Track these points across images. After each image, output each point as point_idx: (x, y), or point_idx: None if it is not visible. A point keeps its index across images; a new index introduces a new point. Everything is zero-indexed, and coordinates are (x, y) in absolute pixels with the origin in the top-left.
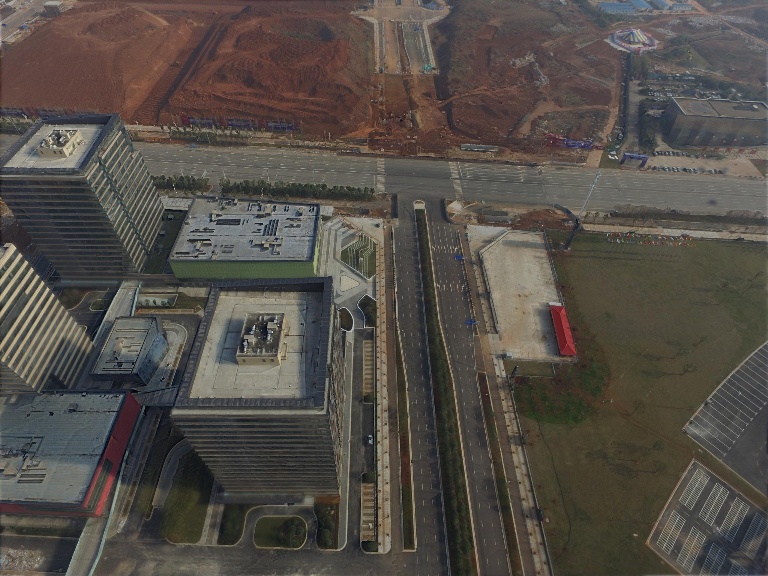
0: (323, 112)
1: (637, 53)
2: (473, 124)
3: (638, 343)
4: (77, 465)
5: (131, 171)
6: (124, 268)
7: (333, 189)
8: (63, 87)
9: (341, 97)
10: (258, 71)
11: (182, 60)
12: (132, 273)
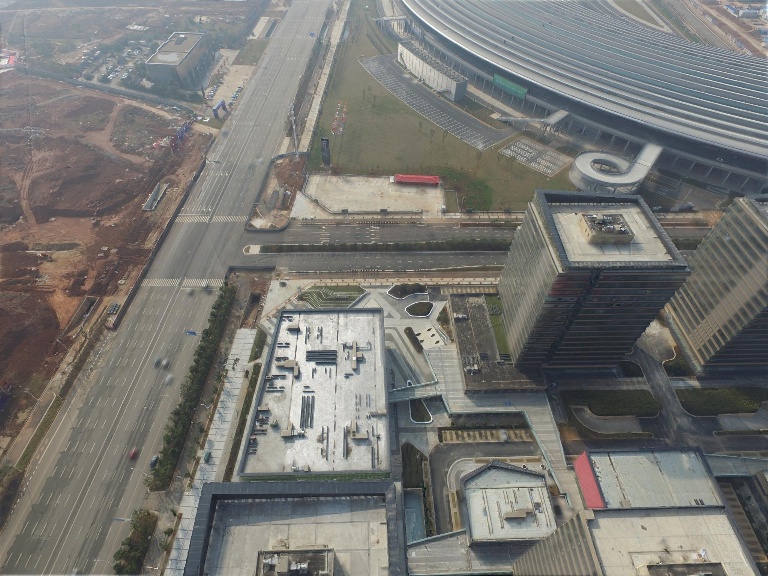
0: None
1: (22, 65)
2: (106, 194)
3: (421, 152)
4: (672, 472)
5: None
6: None
7: None
8: None
9: None
10: None
11: None
12: None
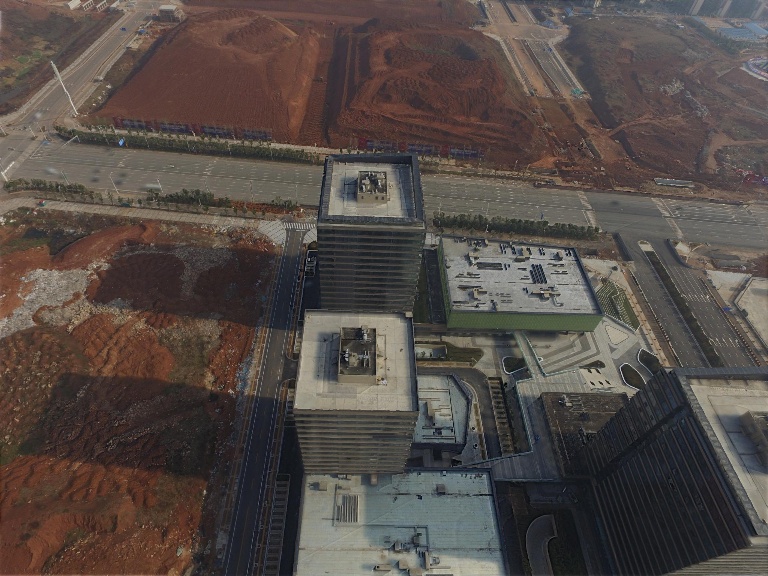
0: (502, 139)
1: None
2: (658, 156)
3: None
4: (481, 563)
5: None
6: None
7: (554, 226)
8: (220, 102)
9: (518, 123)
10: (424, 92)
11: None
12: None
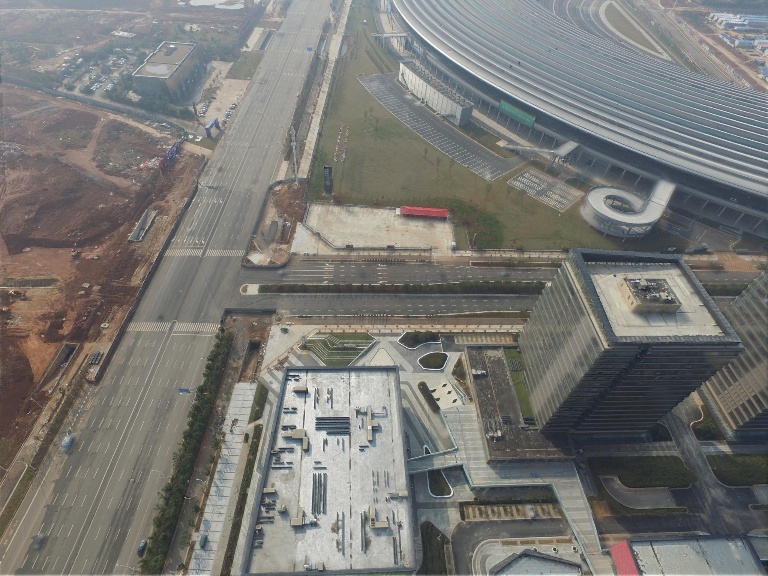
0: None
1: None
2: (88, 221)
3: (427, 181)
4: (720, 565)
5: None
6: None
7: None
8: None
9: None
10: None
11: None
12: None
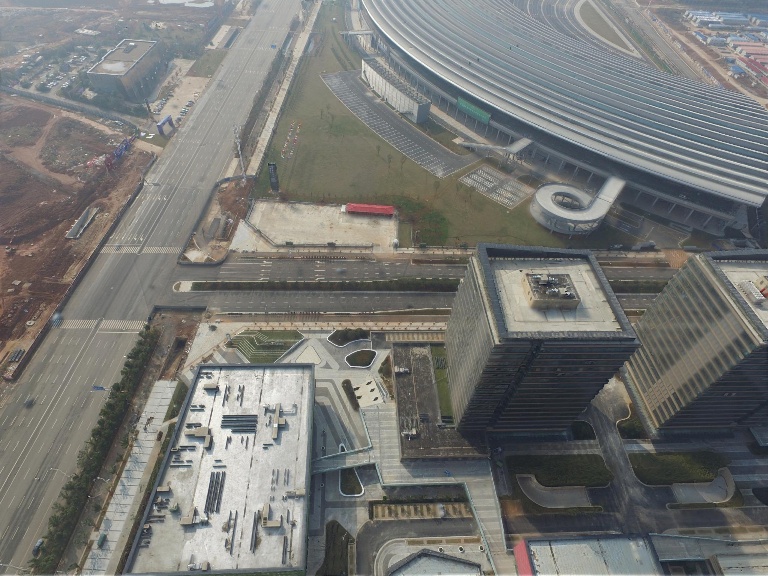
0: None
1: None
2: (26, 219)
3: (378, 178)
4: (618, 565)
5: None
6: None
7: (125, 376)
8: None
9: None
10: None
11: None
12: None
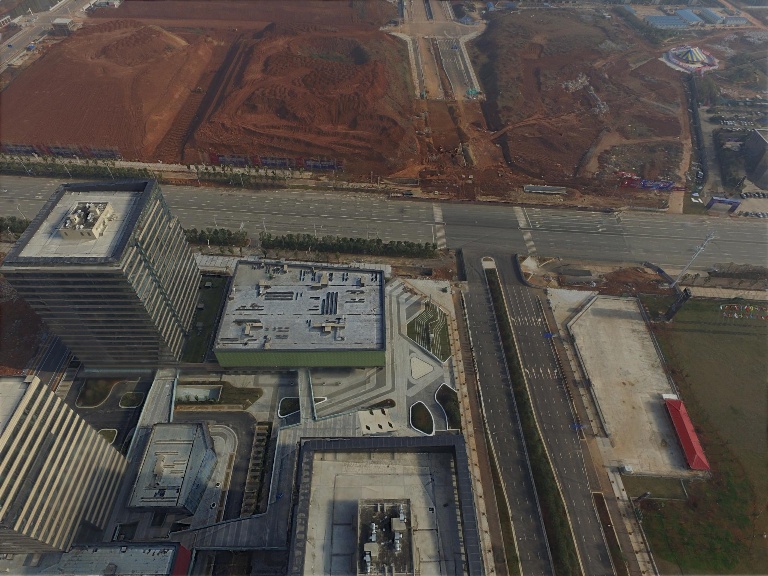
0: (366, 148)
1: (698, 74)
2: (534, 161)
3: None
4: None
5: (169, 244)
6: (160, 357)
7: (389, 244)
8: (77, 119)
9: (385, 130)
10: (292, 100)
11: (204, 85)
12: (169, 362)
